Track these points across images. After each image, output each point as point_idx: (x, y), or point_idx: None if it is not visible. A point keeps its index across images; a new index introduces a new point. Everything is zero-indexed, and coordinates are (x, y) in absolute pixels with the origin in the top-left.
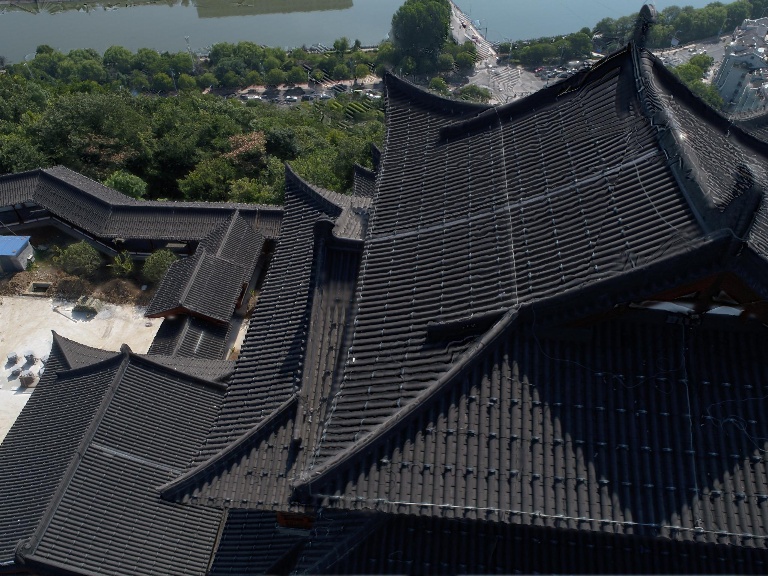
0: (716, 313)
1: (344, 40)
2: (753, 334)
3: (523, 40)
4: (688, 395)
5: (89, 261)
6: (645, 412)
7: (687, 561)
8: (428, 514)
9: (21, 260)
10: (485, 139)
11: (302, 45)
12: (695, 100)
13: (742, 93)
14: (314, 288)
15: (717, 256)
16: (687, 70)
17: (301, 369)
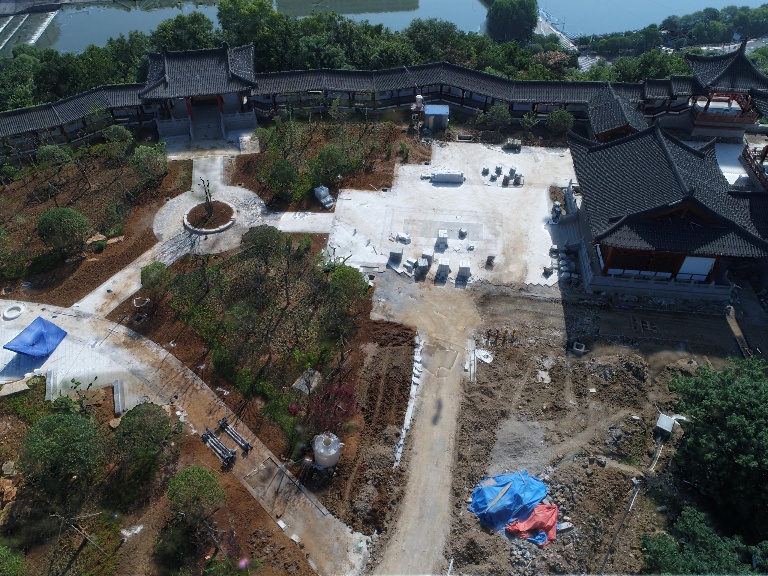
0: None
1: None
2: None
3: (596, 35)
4: None
5: None
6: None
7: None
8: None
9: None
10: None
11: None
12: None
13: None
14: None
15: None
16: None
17: None
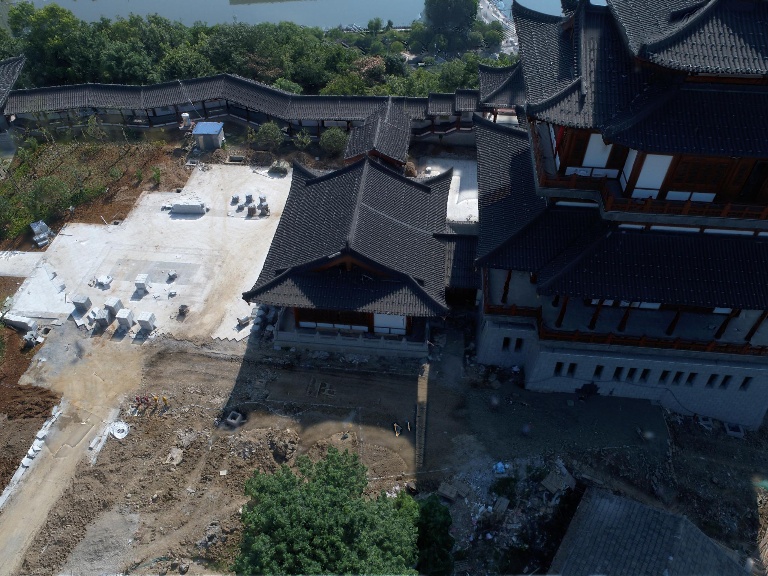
0: None
1: (378, 20)
2: None
3: None
4: None
5: (278, 136)
6: None
7: None
8: (690, 69)
9: (219, 139)
10: None
11: (339, 25)
12: None
13: None
14: (581, 30)
15: None
16: None
17: (577, 70)
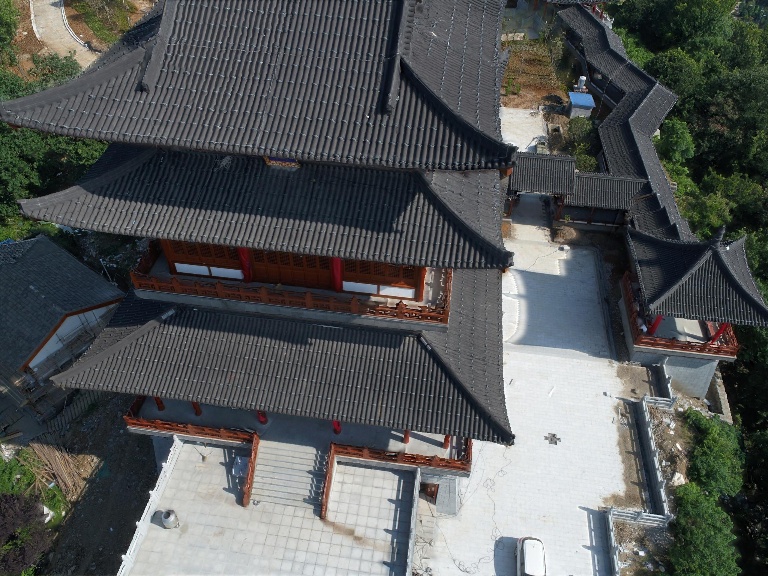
0: None
1: None
2: None
3: None
4: None
5: (574, 132)
6: None
7: None
8: None
9: (574, 112)
10: None
11: None
12: None
13: None
14: None
15: None
16: None
17: None
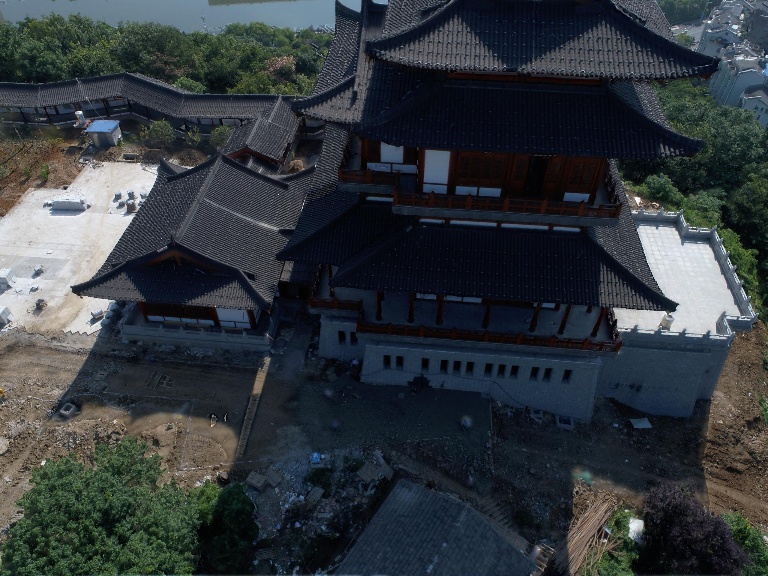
0: None
1: None
2: (566, 5)
3: None
4: (534, 26)
5: (169, 133)
6: (516, 33)
7: (544, 128)
8: (420, 66)
9: (114, 137)
10: None
11: (310, 26)
12: None
13: None
14: (362, 28)
15: None
16: None
17: (356, 67)
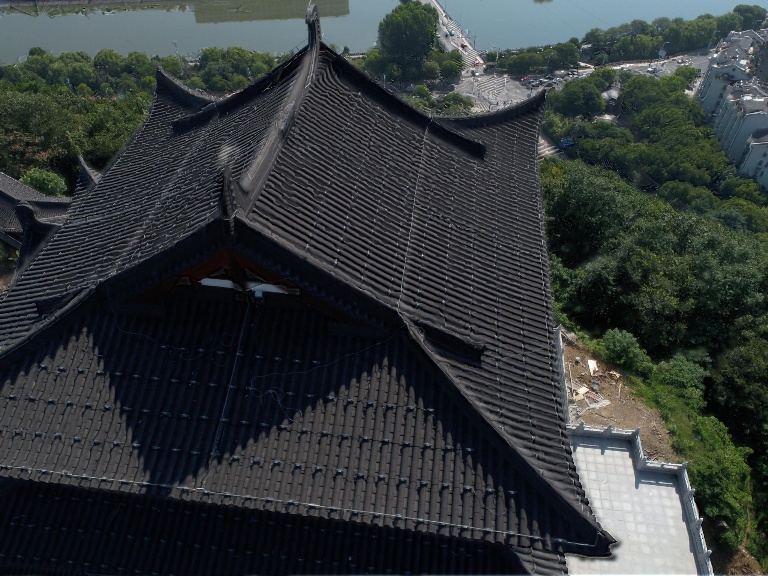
0: (279, 292)
1: (333, 47)
2: (315, 313)
3: (512, 49)
4: (236, 368)
5: None
6: (195, 383)
7: (290, 531)
8: None
9: None
10: (200, 132)
11: (291, 51)
12: (390, 98)
13: (723, 105)
14: None
15: (219, 234)
16: (671, 81)
17: None
